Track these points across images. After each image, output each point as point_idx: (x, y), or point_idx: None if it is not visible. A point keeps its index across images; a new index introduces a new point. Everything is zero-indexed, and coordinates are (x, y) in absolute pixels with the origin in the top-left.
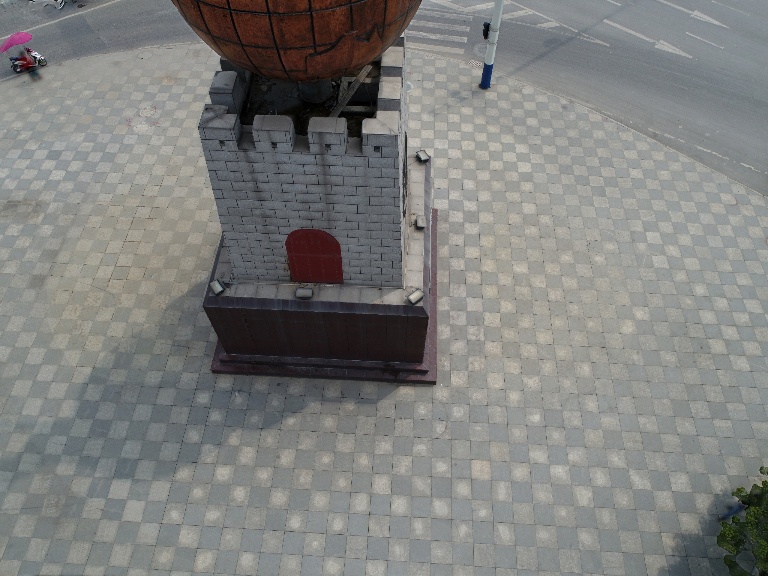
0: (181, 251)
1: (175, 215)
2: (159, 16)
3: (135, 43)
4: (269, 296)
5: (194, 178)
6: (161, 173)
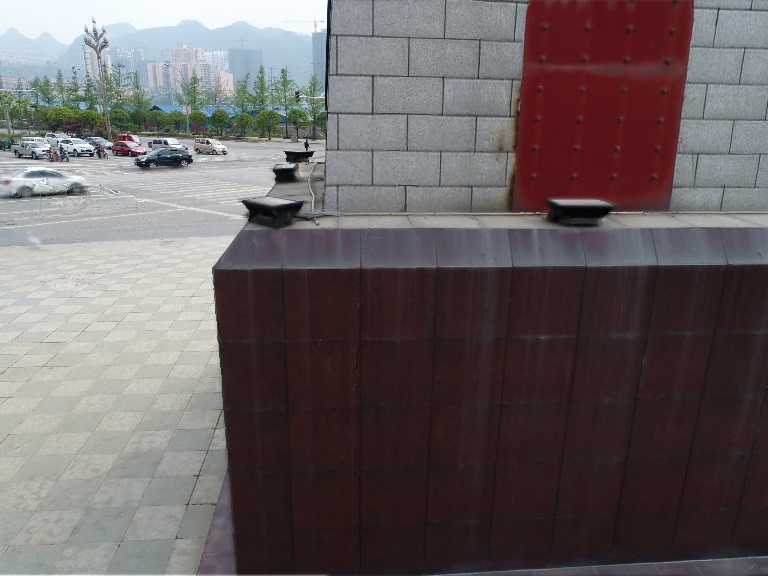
0: (107, 404)
1: (104, 360)
2: (117, 228)
3: (77, 242)
4: (459, 225)
5: (151, 322)
6: (87, 320)
